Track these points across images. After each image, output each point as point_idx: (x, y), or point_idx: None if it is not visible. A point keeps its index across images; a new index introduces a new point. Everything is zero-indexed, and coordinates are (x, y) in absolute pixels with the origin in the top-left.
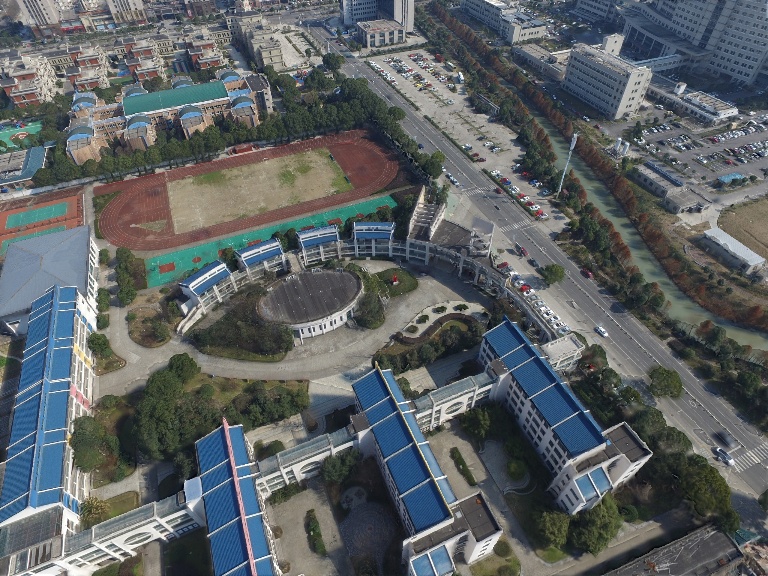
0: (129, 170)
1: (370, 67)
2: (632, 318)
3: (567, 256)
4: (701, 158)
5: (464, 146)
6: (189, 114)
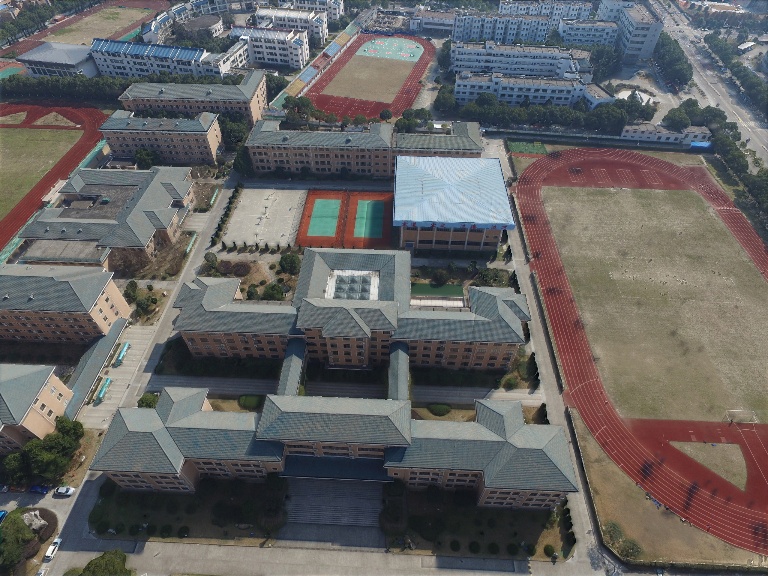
0: (1, 42)
1: None
2: None
3: None
4: None
5: None
6: None
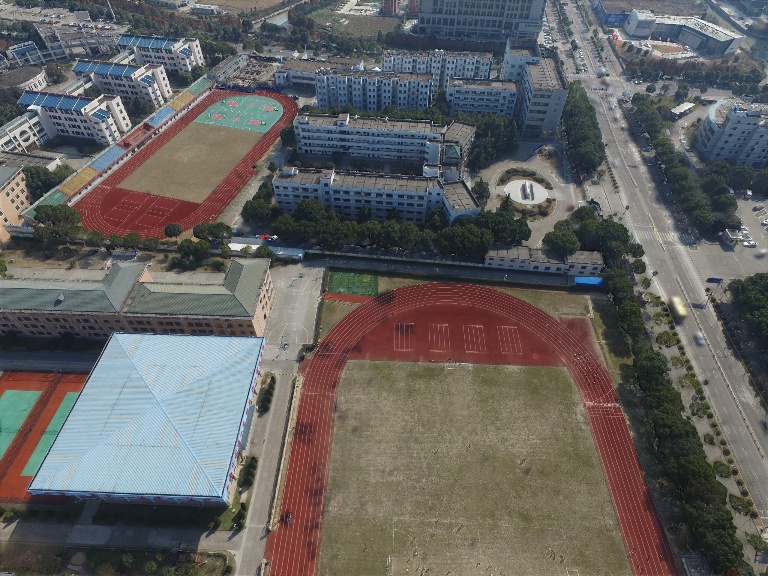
0: None
1: None
2: (181, 39)
3: None
4: None
5: (39, 21)
6: None
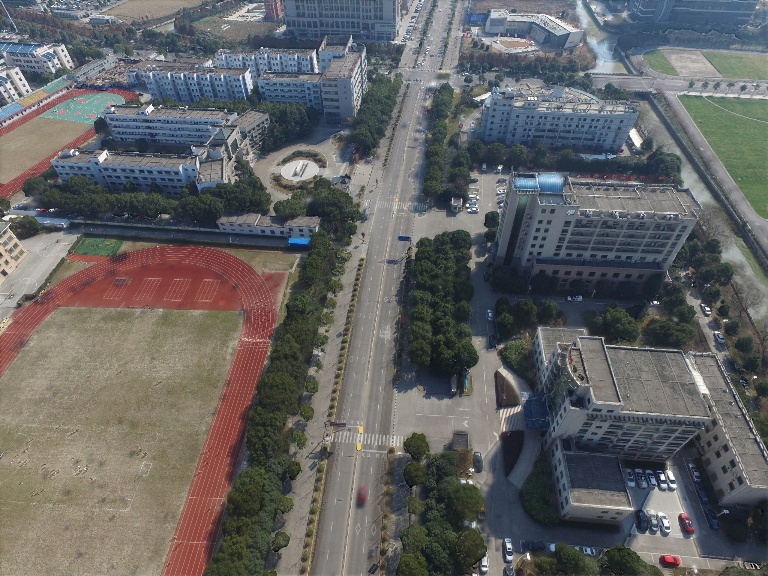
0: None
1: None
2: (68, 46)
3: None
4: (86, 3)
5: None
6: None
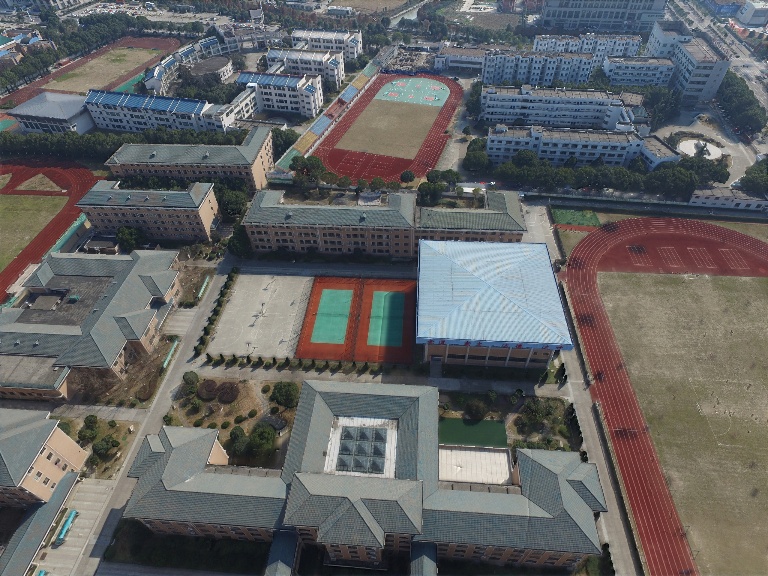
0: None
1: (78, 17)
2: None
3: None
4: None
5: None
6: (1, 53)
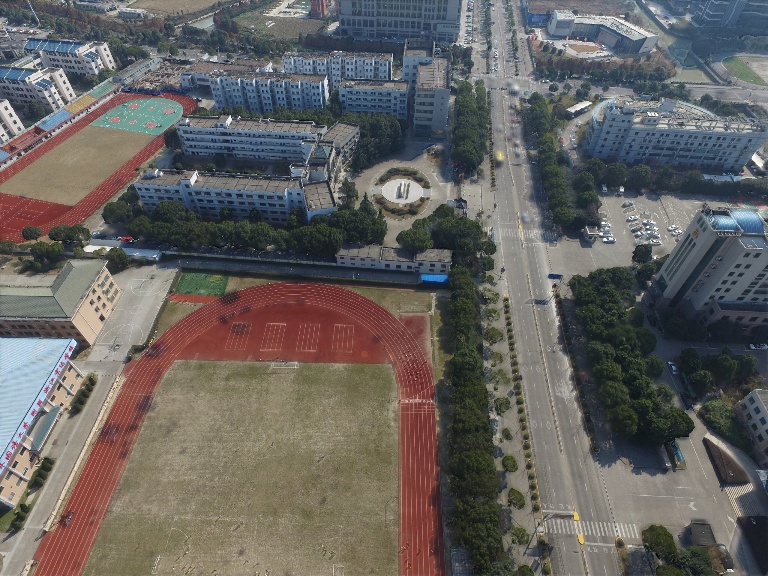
0: None
1: None
2: None
3: (60, 39)
4: None
5: None
6: None
